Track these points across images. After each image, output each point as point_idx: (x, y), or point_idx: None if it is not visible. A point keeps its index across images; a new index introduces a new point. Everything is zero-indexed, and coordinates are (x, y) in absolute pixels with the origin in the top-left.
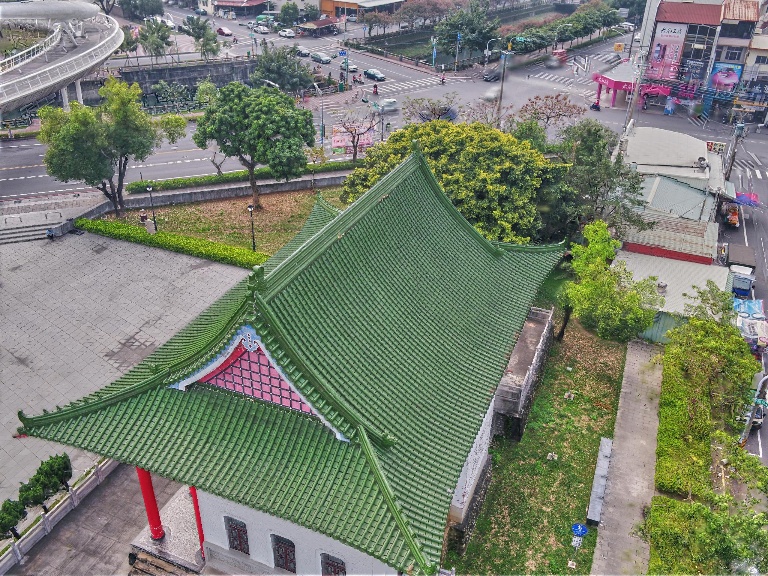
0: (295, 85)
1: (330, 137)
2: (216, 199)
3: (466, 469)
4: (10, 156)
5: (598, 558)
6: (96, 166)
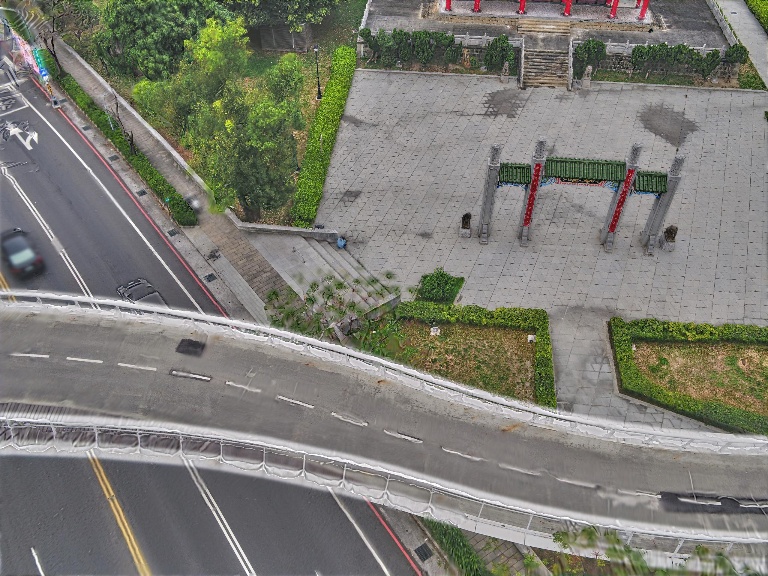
0: None
1: None
2: None
3: None
4: None
5: None
6: None
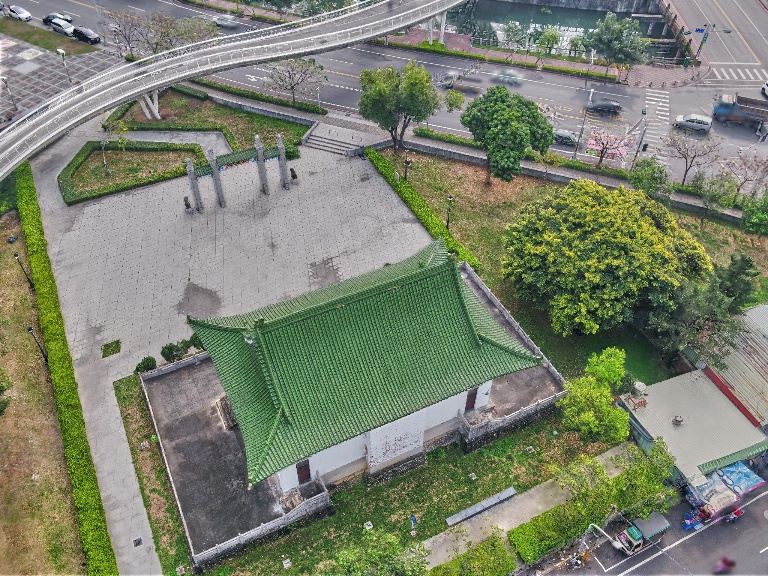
0: (621, 59)
1: (587, 139)
2: (468, 162)
3: (370, 451)
4: (373, 65)
5: (430, 541)
6: (386, 118)
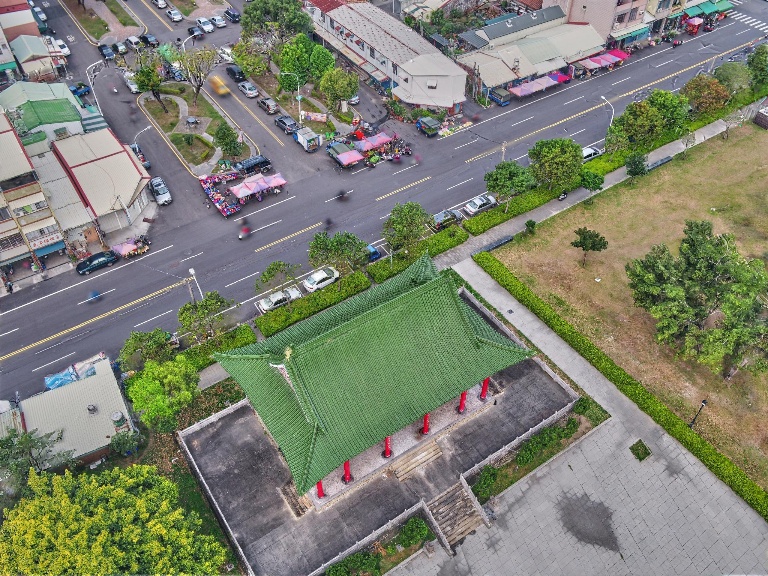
0: None
1: None
2: None
3: None
4: None
5: None
6: None
